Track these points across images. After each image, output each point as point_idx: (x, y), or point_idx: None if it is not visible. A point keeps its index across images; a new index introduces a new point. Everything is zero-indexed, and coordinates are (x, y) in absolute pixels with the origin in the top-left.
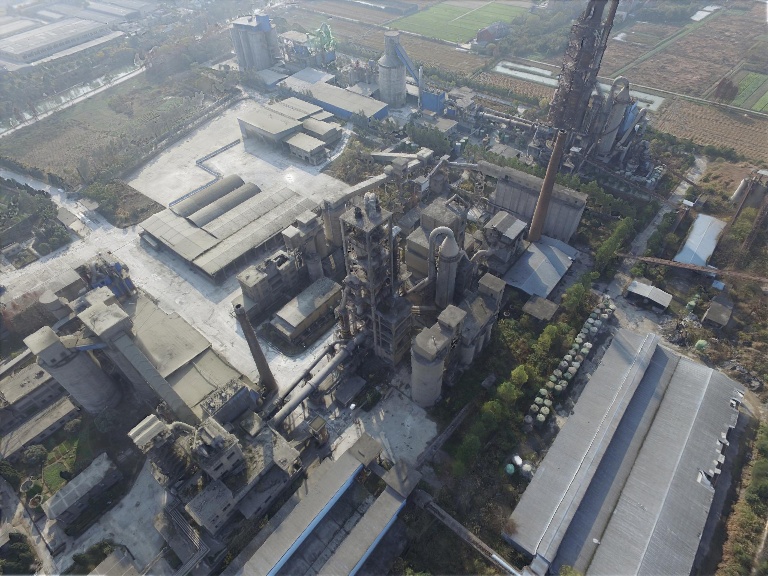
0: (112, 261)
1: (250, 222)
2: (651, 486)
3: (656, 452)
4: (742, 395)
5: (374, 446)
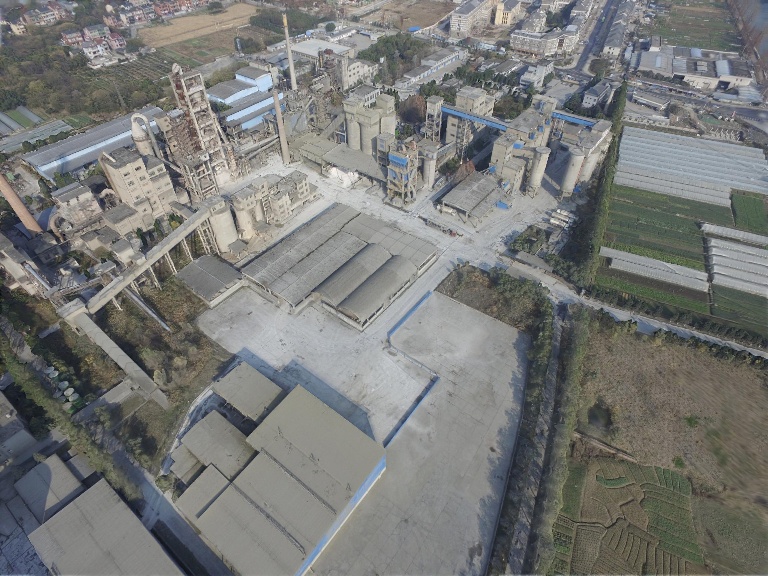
0: (393, 153)
1: (317, 249)
2: (113, 129)
3: (98, 137)
4: (26, 153)
5: (228, 123)
